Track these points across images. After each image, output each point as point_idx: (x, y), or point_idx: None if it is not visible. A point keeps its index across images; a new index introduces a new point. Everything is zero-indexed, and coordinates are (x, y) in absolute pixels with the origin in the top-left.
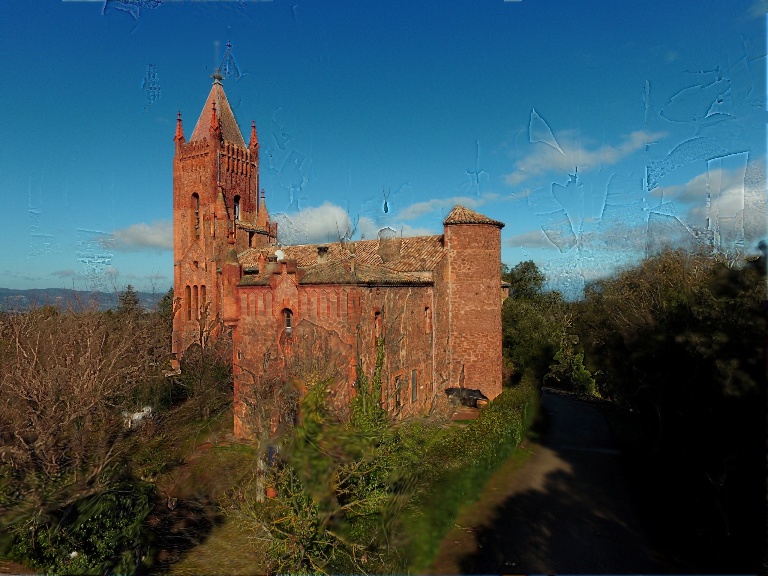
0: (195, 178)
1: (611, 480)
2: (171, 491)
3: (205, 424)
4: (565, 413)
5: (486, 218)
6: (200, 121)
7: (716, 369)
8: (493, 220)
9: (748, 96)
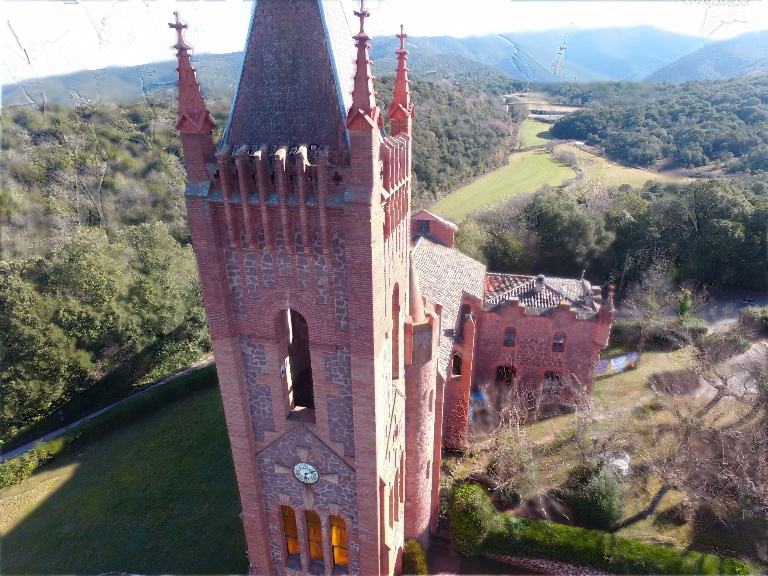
0: (395, 246)
1: None
2: None
3: None
4: None
5: None
6: None
7: (579, 264)
8: None
9: (99, 3)
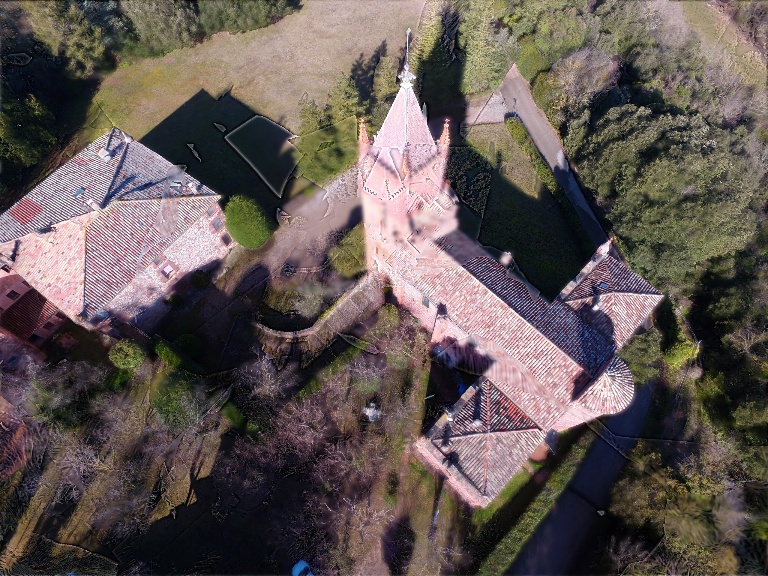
0: None
1: (569, 550)
2: (399, 514)
3: (417, 574)
4: (620, 415)
5: (614, 405)
6: (385, 128)
7: None
8: (619, 408)
9: None
